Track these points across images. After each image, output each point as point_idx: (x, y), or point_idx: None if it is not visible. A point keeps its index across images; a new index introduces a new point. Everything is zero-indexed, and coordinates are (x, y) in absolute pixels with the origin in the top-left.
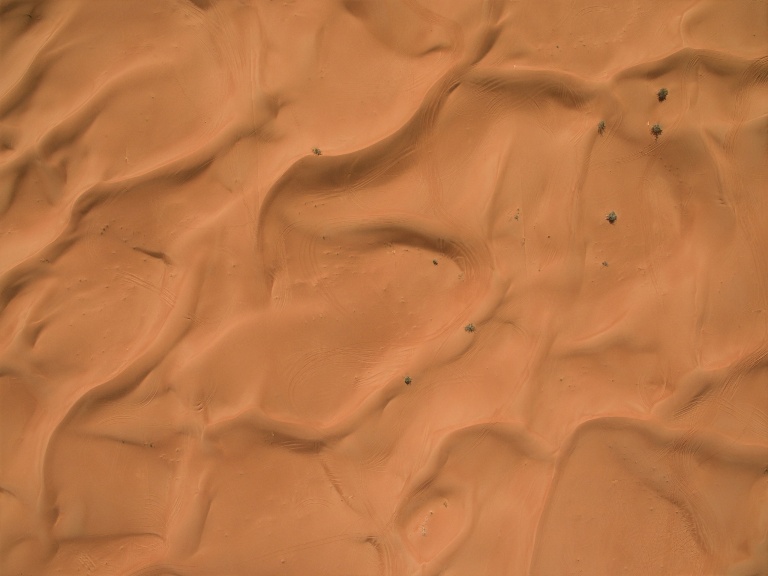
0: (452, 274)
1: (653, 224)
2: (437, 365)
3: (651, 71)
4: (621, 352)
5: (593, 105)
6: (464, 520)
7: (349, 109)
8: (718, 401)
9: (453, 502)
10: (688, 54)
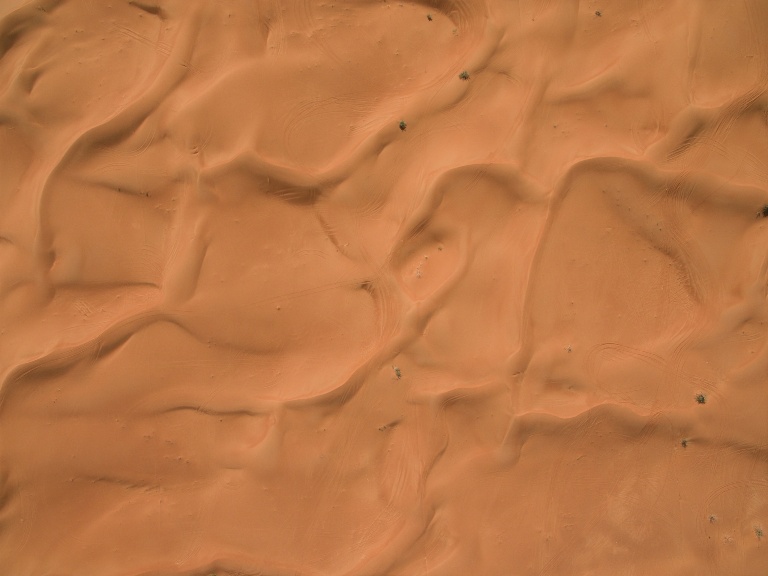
0: (446, 29)
1: None
2: (432, 113)
3: None
4: (614, 96)
5: None
6: (459, 260)
7: None
8: (711, 142)
9: (448, 244)
10: None
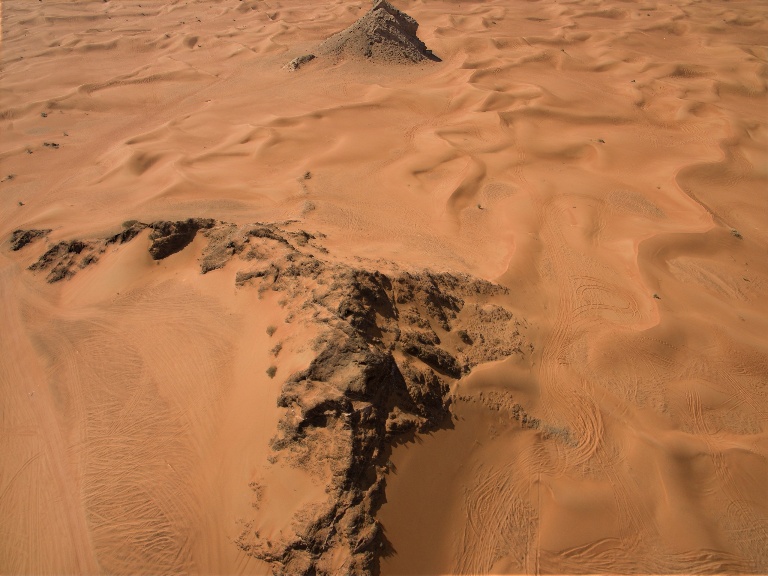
0: None
1: None
2: None
3: None
4: None
5: None
6: None
7: None
8: None
9: None
10: None
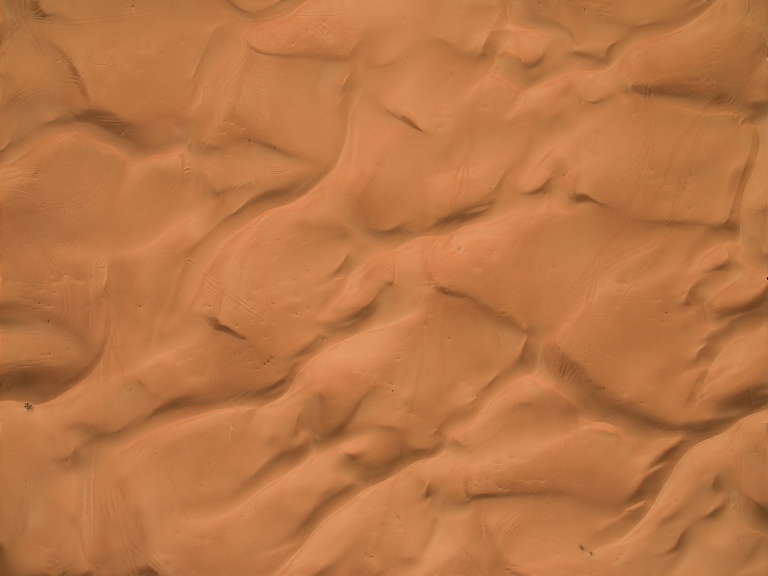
0: None
1: None
2: None
3: None
4: None
5: None
6: None
7: (2, 446)
8: None
9: None
10: None
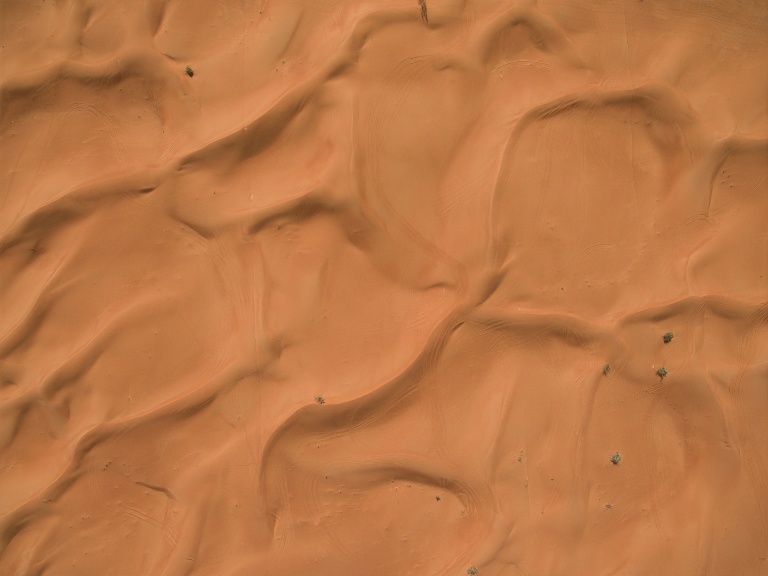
0: (455, 510)
1: (657, 462)
2: None
3: (656, 316)
4: None
5: (598, 347)
6: None
7: (352, 351)
8: None
9: None
10: (694, 302)
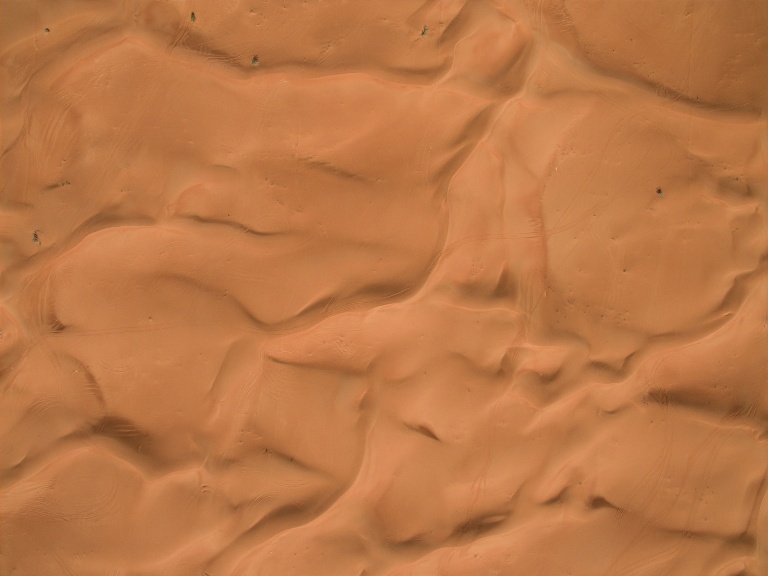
0: None
1: None
2: None
3: None
4: None
5: None
6: None
7: None
8: None
9: None
10: None
